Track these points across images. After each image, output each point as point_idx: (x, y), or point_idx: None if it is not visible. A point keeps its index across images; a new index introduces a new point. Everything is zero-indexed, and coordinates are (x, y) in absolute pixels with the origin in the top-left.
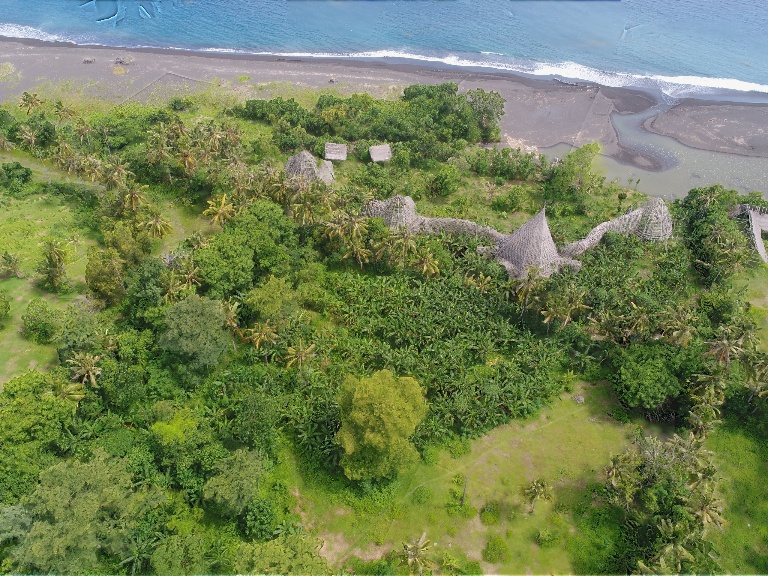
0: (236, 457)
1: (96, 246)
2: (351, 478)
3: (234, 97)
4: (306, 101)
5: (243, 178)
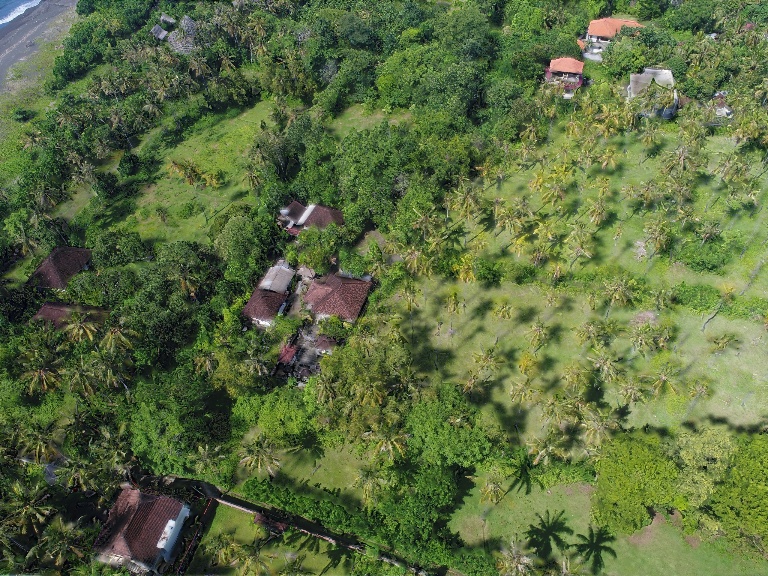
0: (432, 10)
1: (278, 69)
2: (429, 8)
3: (25, 89)
4: (59, 55)
5: (219, 26)
